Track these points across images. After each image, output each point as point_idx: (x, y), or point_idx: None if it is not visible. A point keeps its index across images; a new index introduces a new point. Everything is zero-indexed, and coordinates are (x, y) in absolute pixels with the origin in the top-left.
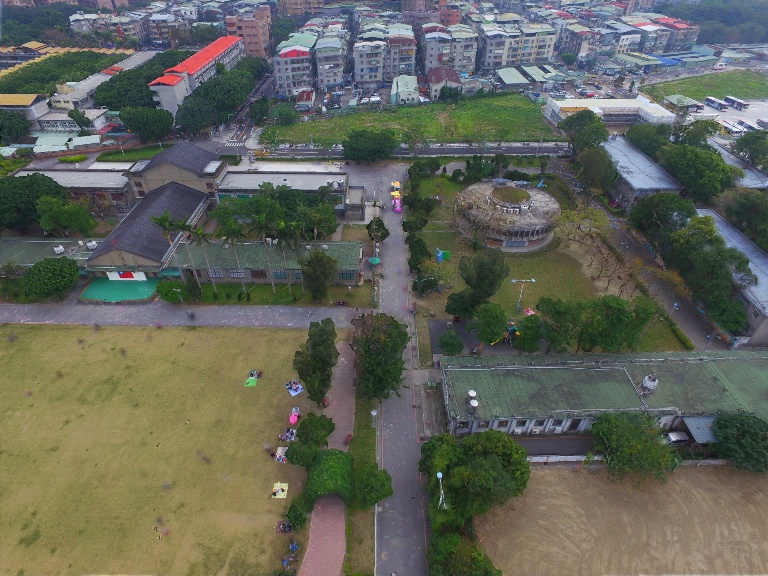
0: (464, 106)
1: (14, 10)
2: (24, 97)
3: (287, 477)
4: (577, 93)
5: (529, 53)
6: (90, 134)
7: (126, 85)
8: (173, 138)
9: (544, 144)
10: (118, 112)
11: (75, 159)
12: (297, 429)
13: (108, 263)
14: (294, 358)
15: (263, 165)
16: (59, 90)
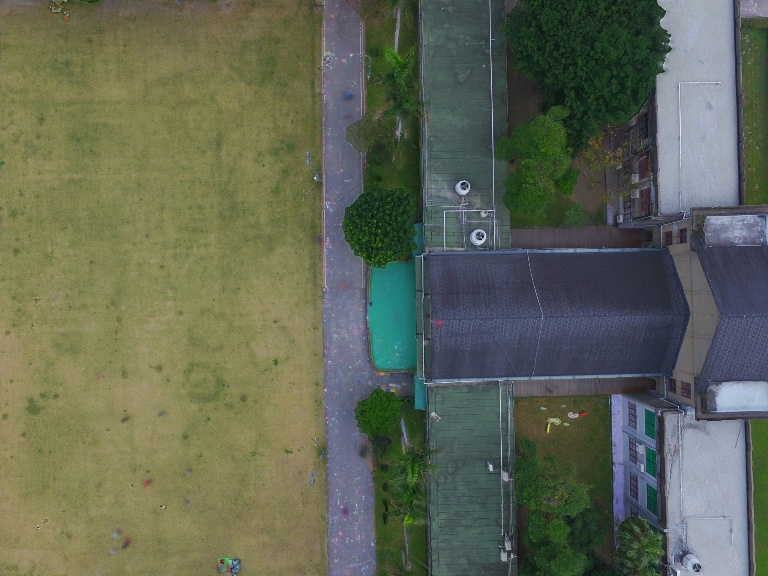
0: None
1: None
2: None
3: None
4: None
5: None
6: None
7: None
8: None
9: None
10: None
11: None
12: None
13: None
14: None
15: None
16: None
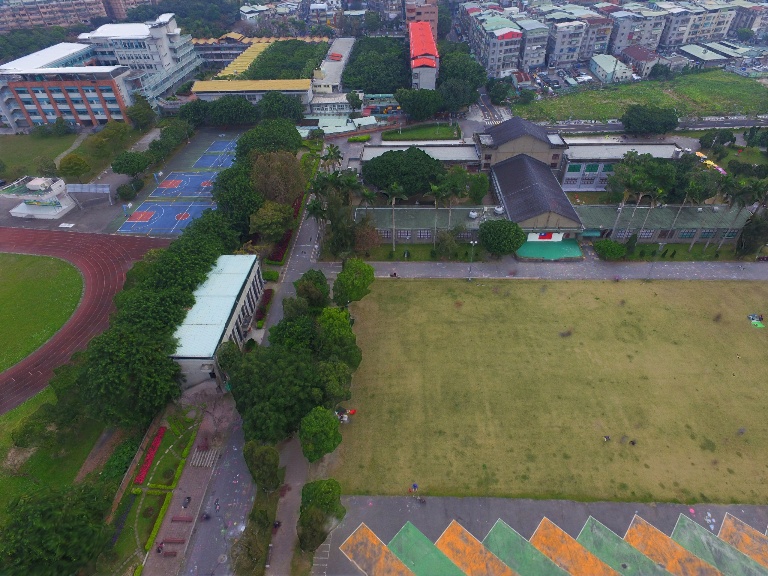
0: (679, 82)
1: (173, 4)
2: (300, 82)
3: None
4: None
5: (708, 30)
6: (360, 116)
7: (373, 69)
8: (432, 118)
9: None
10: (375, 95)
11: (364, 139)
12: None
13: (531, 225)
14: None
15: None
16: (315, 75)
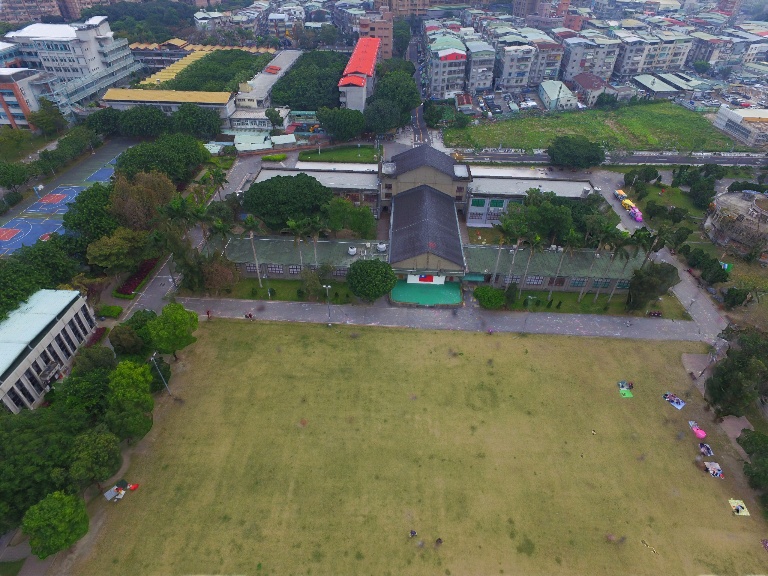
0: (624, 113)
1: (130, 6)
2: (219, 95)
3: (736, 494)
4: (728, 102)
5: (664, 60)
6: (281, 133)
7: (304, 85)
8: (358, 139)
9: (736, 154)
10: (301, 112)
11: (279, 158)
12: (743, 445)
13: (410, 266)
14: (650, 370)
15: None
16: (241, 88)
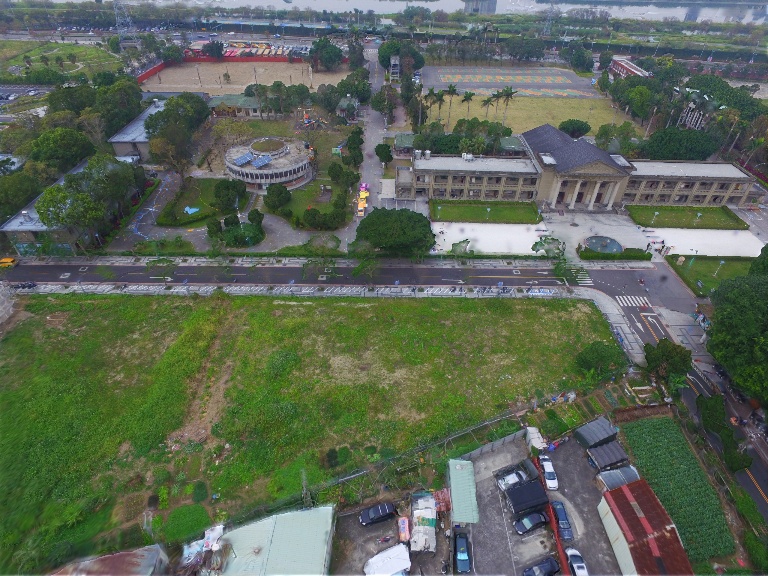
0: None
1: None
2: None
3: None
4: None
5: None
6: None
7: None
8: None
9: (87, 287)
10: None
11: None
12: None
13: None
14: None
15: (543, 251)
16: None
